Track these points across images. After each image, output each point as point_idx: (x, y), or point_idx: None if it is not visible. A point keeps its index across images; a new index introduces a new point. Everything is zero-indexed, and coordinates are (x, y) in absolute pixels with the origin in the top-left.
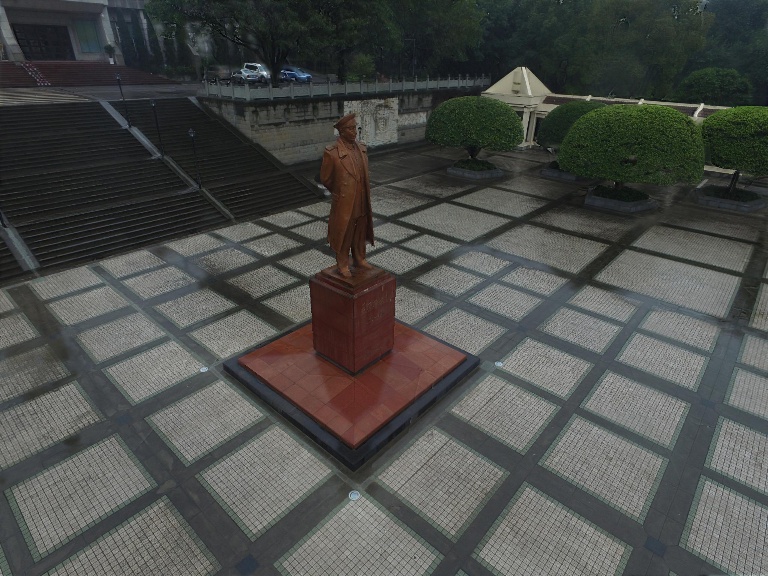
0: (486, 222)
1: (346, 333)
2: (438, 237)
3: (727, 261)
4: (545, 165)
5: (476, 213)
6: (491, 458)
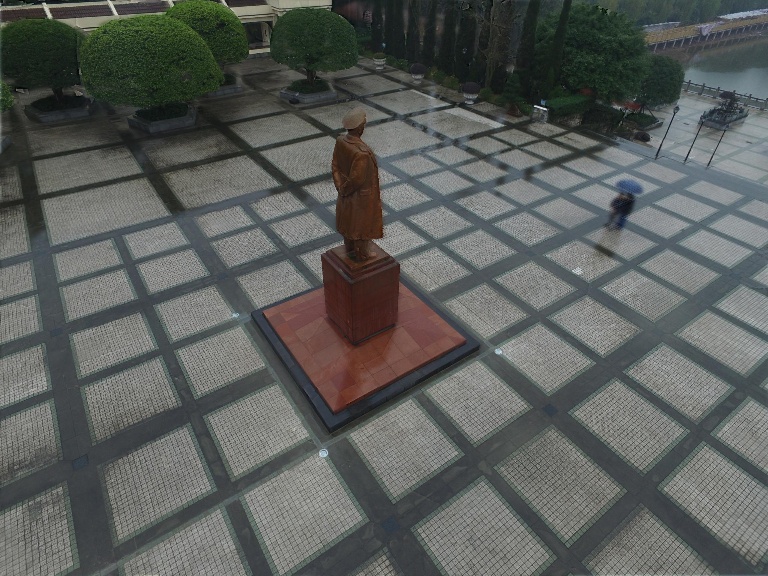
0: (134, 192)
1: (391, 297)
2: (141, 230)
3: (306, 129)
4: (18, 111)
5: (102, 190)
6: (474, 286)
